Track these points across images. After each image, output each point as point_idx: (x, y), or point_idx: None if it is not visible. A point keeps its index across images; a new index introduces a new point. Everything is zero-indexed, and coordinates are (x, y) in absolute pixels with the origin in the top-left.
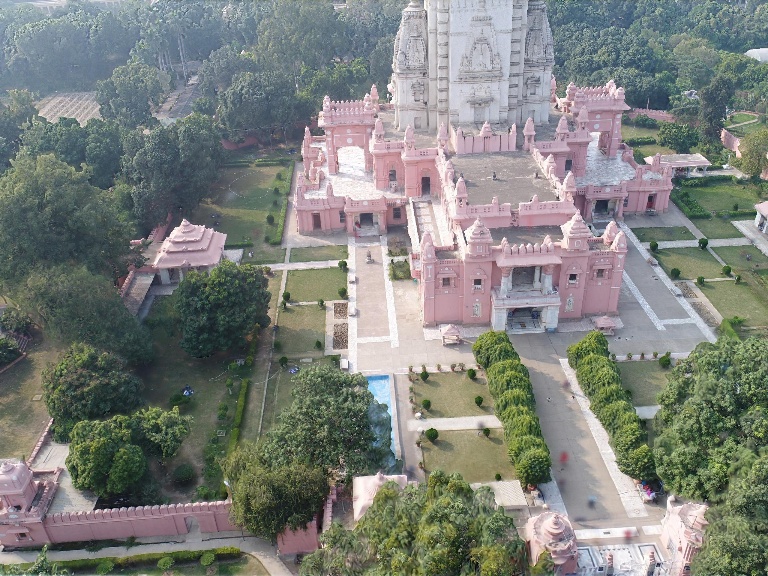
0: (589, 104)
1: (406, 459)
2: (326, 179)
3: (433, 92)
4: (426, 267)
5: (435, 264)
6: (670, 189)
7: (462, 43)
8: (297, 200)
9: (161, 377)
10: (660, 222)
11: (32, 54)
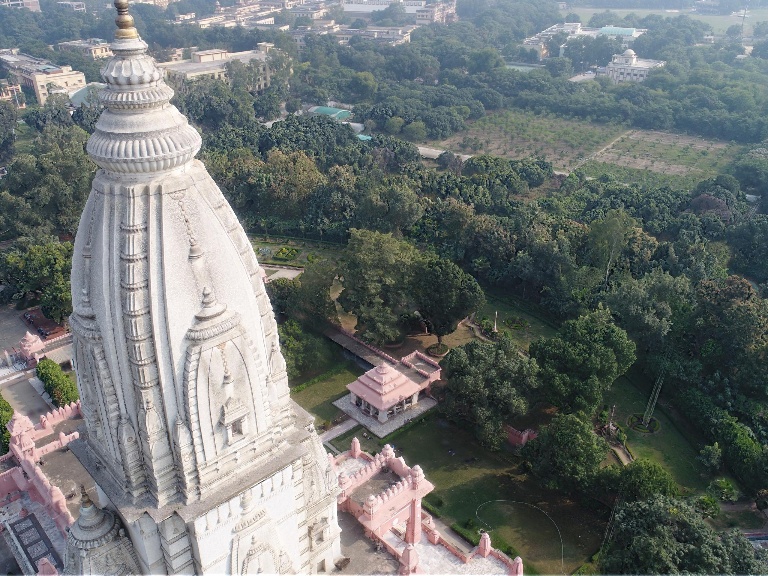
0: None
1: None
2: None
3: None
4: None
5: None
6: None
7: None
8: None
9: None
10: None
11: None
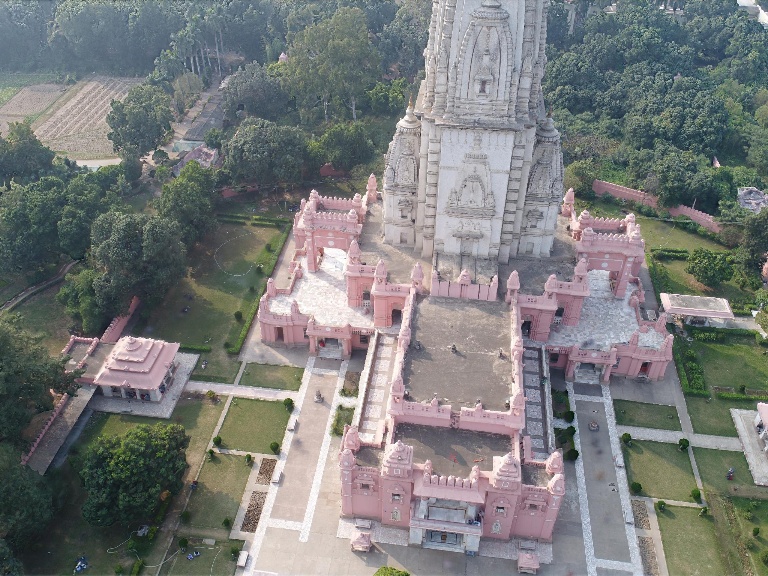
0: (598, 243)
1: None
2: (302, 279)
3: (421, 214)
4: (342, 472)
5: (352, 470)
6: (668, 360)
7: (452, 177)
8: (260, 312)
9: (63, 536)
10: (649, 395)
11: (70, 34)
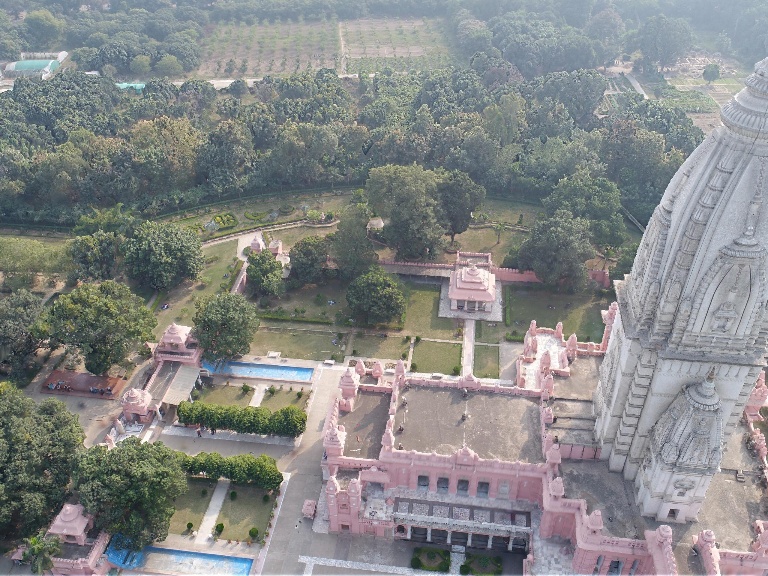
0: None
1: (238, 379)
2: None
3: None
4: None
5: None
6: None
7: None
8: None
9: None
10: None
11: None
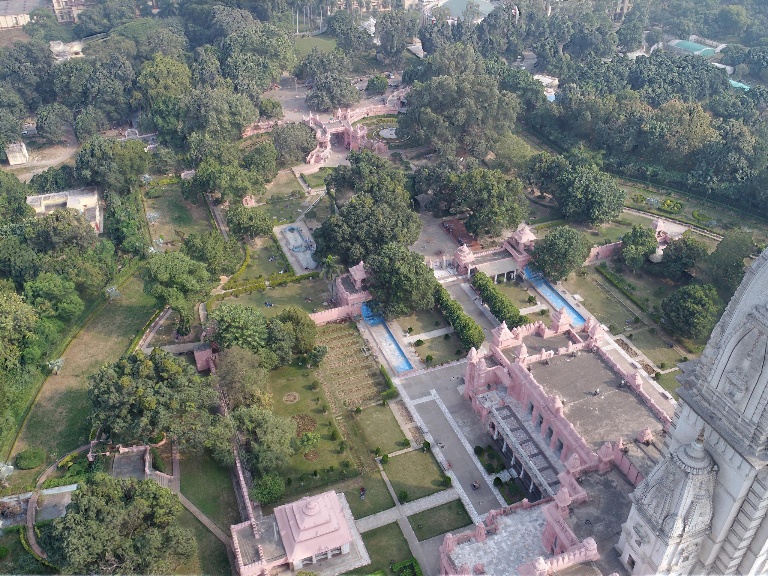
0: None
1: (537, 293)
2: None
3: None
4: None
5: None
6: None
7: None
8: None
9: None
10: None
11: None
